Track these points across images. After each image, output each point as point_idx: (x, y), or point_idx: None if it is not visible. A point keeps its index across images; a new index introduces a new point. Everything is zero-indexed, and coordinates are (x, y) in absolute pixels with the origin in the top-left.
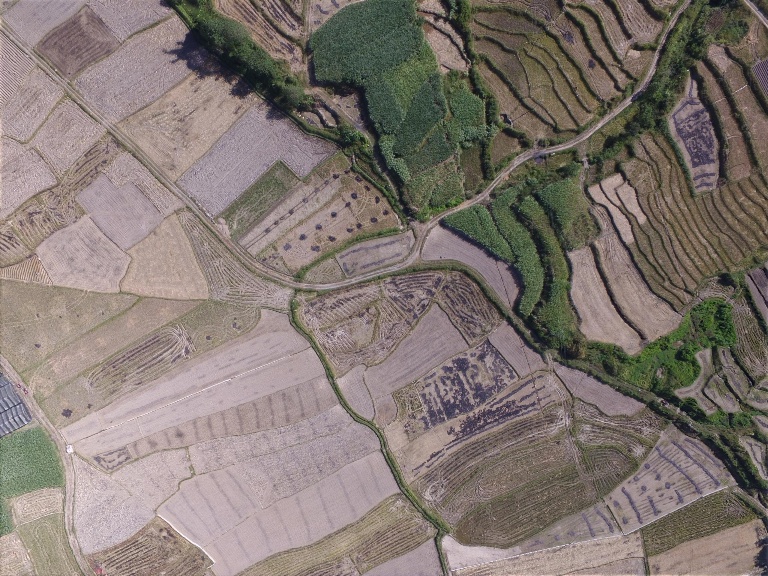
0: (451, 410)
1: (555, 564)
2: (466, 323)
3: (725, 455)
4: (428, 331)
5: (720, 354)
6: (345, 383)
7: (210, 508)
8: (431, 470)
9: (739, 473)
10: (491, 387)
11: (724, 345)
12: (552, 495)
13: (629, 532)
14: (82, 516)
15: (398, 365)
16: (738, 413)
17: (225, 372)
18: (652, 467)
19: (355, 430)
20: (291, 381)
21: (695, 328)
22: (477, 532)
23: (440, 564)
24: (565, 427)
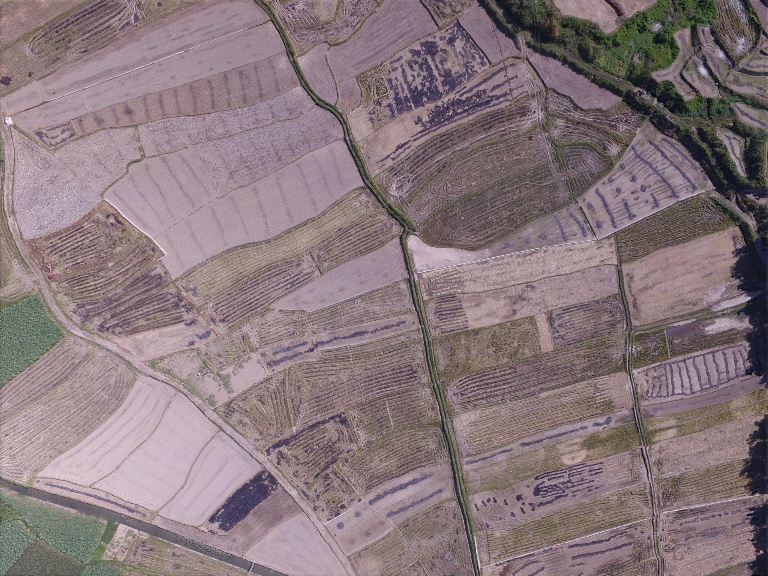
0: (419, 98)
1: (525, 270)
2: (435, 1)
3: (703, 153)
4: (395, 9)
5: (699, 32)
6: (306, 62)
7: (161, 195)
8: (397, 163)
9: (717, 173)
10: (461, 74)
11: (704, 22)
12: (523, 194)
13: (603, 236)
14: (22, 197)
15: (363, 45)
16: (717, 98)
17: (178, 44)
18: (627, 168)
19: (317, 115)
20: (249, 57)
21: (674, 7)
22: (445, 232)
23: (405, 265)
24: (538, 121)
